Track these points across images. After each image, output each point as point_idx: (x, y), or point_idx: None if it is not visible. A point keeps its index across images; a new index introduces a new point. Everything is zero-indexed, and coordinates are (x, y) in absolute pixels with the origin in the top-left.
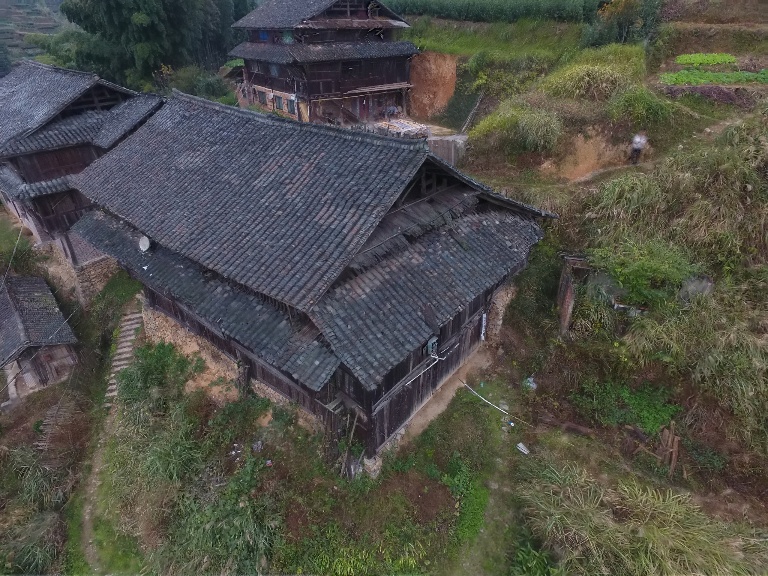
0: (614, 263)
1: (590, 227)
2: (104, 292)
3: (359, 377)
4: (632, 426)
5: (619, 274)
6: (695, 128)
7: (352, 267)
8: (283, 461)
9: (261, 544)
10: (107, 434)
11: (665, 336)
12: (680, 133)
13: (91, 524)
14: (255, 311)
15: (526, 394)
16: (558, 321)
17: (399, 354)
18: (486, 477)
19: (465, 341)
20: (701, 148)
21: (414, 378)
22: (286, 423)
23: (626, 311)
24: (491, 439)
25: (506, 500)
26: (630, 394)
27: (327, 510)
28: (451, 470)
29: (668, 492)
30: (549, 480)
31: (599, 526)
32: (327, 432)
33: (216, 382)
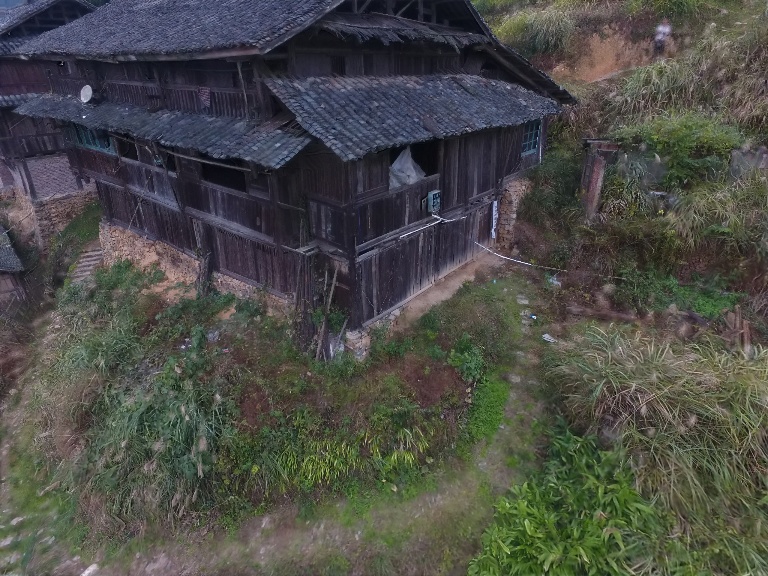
0: (650, 128)
1: (613, 122)
2: (65, 232)
3: (332, 146)
4: (686, 311)
5: (656, 141)
6: (724, 23)
7: (327, 27)
8: (243, 346)
9: (202, 426)
10: (45, 366)
11: (719, 206)
12: (707, 28)
13: (8, 460)
14: (206, 121)
15: (549, 287)
16: (584, 208)
17: (389, 141)
18: (504, 370)
19: (473, 227)
20: (734, 36)
21: (411, 232)
22: (252, 314)
23: (664, 197)
24: (509, 333)
25: (532, 391)
26: (678, 285)
27: (295, 391)
28: (459, 349)
29: (756, 348)
30: (591, 345)
31: (670, 376)
32: (299, 301)
33: (173, 287)
